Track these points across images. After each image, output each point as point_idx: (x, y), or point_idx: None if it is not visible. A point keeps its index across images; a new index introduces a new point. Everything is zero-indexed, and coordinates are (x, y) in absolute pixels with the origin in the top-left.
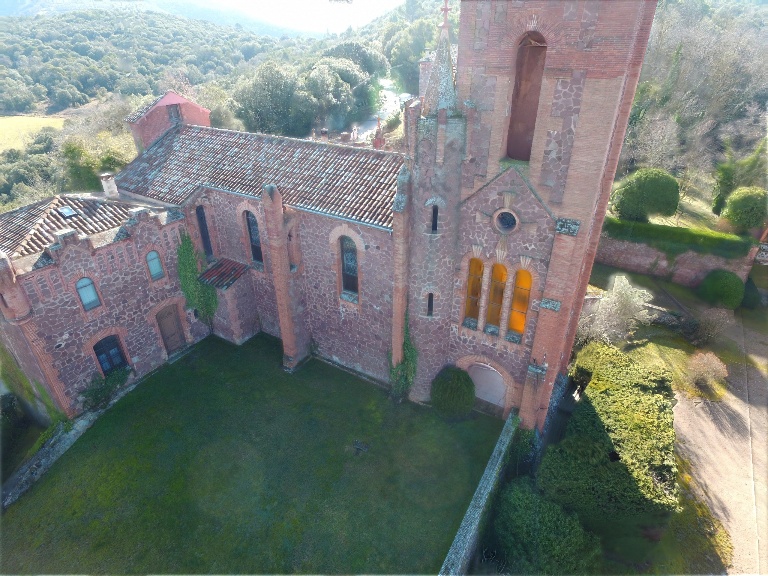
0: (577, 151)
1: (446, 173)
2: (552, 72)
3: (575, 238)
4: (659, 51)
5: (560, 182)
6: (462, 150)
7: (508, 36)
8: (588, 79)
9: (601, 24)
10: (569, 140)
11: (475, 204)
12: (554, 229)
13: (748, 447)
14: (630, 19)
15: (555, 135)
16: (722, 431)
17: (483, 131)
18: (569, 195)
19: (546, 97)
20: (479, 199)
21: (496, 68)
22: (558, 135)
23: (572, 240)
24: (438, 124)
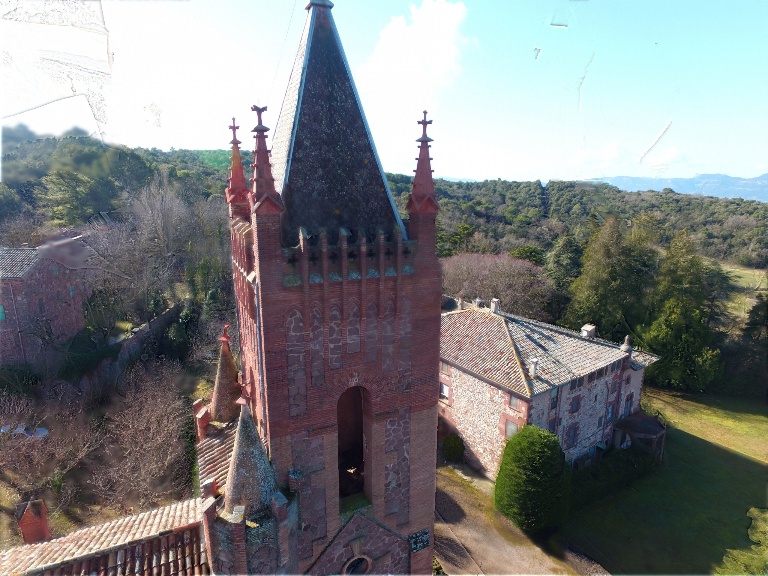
0: (414, 473)
1: (290, 567)
2: (381, 417)
3: (428, 546)
4: (204, 231)
5: (404, 504)
6: (297, 526)
7: (330, 396)
8: (413, 413)
9: (415, 370)
10: (405, 466)
11: (317, 571)
12: (407, 548)
13: (475, 565)
14: (436, 362)
15: (392, 467)
16: (456, 565)
17: (315, 493)
18: (414, 512)
19: (378, 439)
20: (322, 563)
21: (322, 429)
22: (394, 466)
23: (426, 549)
24: (279, 524)
